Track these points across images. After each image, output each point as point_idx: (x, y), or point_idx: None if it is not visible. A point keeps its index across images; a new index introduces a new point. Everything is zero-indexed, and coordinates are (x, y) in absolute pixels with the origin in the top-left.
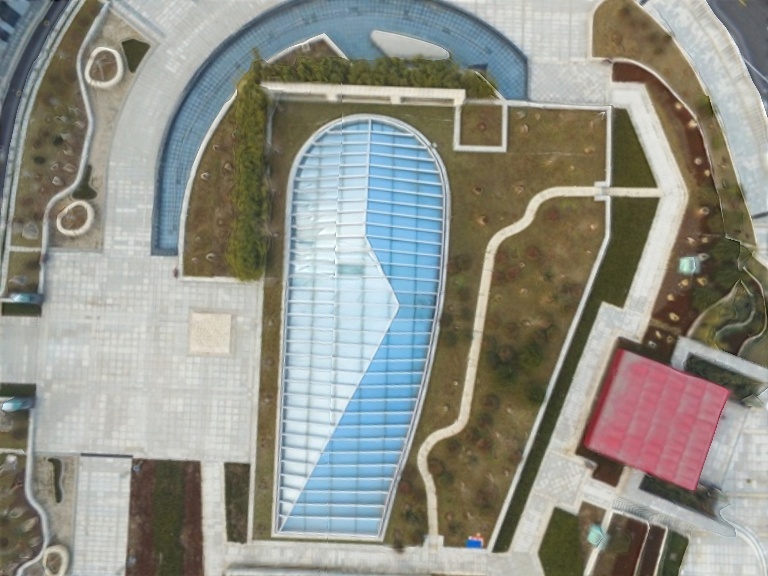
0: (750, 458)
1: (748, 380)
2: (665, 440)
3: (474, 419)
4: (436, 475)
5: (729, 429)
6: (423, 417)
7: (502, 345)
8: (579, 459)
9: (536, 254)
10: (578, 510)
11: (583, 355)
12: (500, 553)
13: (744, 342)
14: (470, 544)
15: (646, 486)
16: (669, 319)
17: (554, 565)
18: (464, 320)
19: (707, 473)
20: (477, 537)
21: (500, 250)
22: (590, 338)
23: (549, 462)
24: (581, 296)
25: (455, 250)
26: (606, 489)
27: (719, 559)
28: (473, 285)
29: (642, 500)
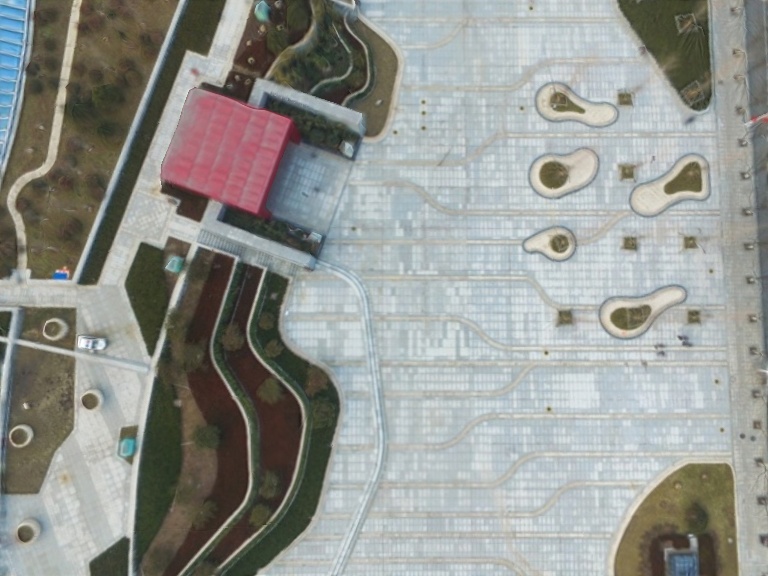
0: (355, 208)
1: (331, 122)
2: (230, 168)
3: (59, 160)
4: (21, 212)
5: (334, 181)
6: (11, 160)
7: (85, 90)
8: (165, 197)
9: (116, 4)
10: (164, 245)
11: (168, 101)
12: (88, 286)
13: (346, 98)
14: (56, 276)
15: (223, 217)
16: (247, 63)
17: (138, 294)
18: (50, 69)
19: (313, 222)
20: (64, 270)
21: (84, 2)
22: (175, 85)
23: (136, 201)
24: (161, 43)
25: (42, 4)
26: (191, 224)
27: (322, 300)
28: (60, 37)
29: (220, 230)
